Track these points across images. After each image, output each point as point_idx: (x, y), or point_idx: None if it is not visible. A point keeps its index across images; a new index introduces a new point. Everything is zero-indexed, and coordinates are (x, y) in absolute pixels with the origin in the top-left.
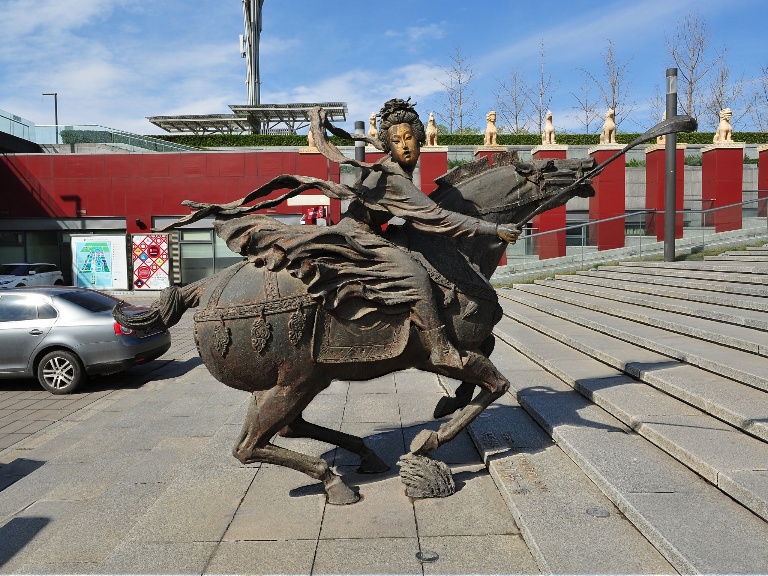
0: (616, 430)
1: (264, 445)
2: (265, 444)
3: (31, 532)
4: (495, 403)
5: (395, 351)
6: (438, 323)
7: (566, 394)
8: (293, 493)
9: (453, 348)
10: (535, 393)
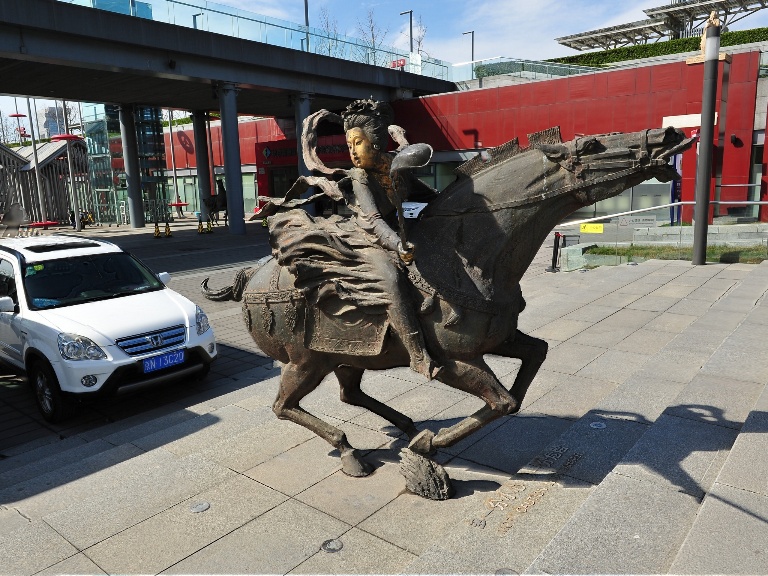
0: (692, 493)
1: (291, 408)
2: (292, 407)
3: (202, 426)
4: (638, 414)
5: (377, 350)
6: (409, 329)
7: (726, 426)
8: (333, 452)
9: (427, 357)
10: (685, 414)
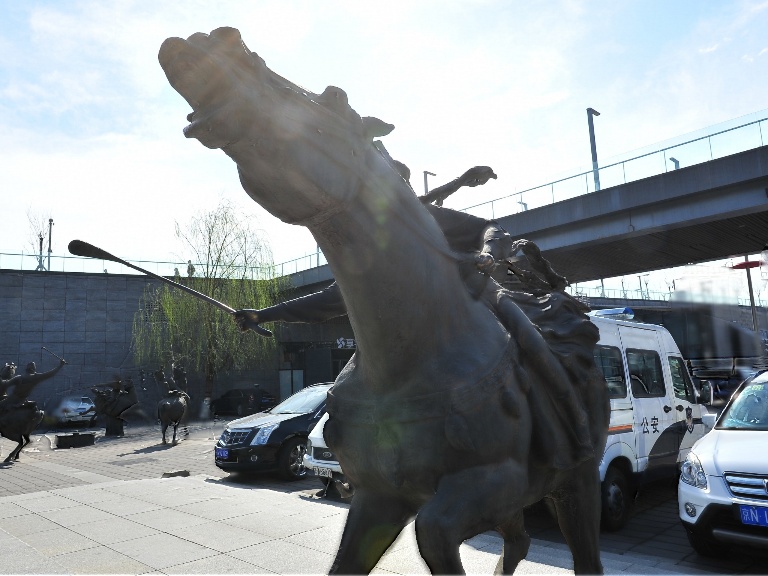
0: None
1: None
2: None
3: None
4: None
5: None
6: None
7: None
8: None
9: None
10: None
